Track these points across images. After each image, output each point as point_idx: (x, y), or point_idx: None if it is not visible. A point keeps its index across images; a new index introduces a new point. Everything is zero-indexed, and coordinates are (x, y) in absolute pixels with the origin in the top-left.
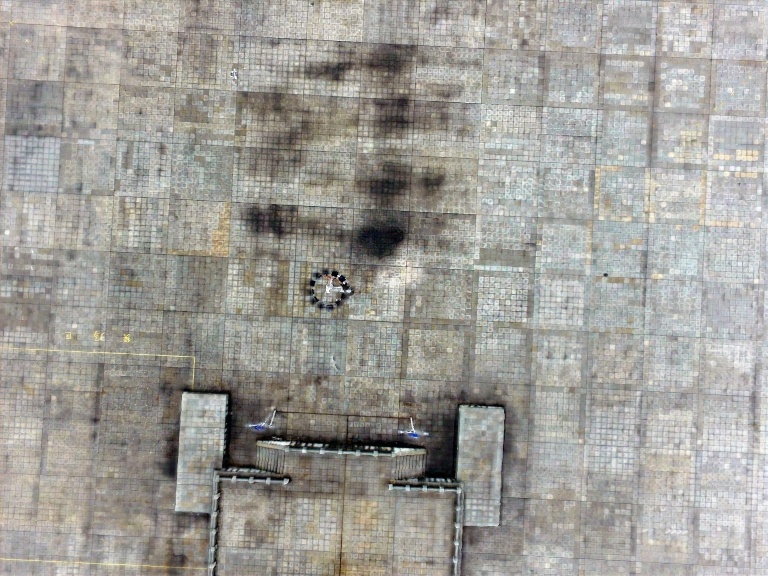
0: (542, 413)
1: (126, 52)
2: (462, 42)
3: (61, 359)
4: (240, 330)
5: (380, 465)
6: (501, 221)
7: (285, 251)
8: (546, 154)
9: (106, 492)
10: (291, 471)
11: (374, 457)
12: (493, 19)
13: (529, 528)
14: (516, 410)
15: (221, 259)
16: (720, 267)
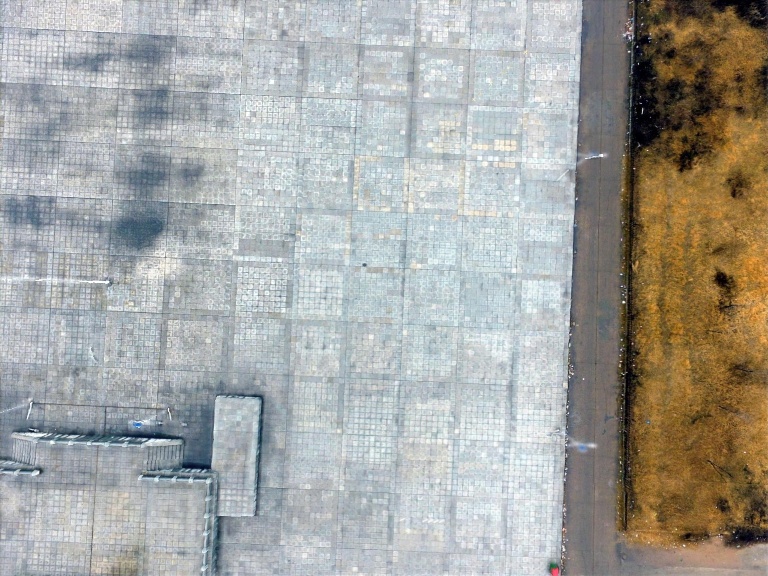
0: (300, 403)
1: None
2: (221, 33)
3: None
4: None
5: (132, 456)
6: (260, 211)
7: (43, 242)
8: (305, 144)
9: None
10: (43, 462)
11: (126, 448)
12: (252, 10)
13: (286, 518)
14: (274, 400)
15: None
16: (478, 256)
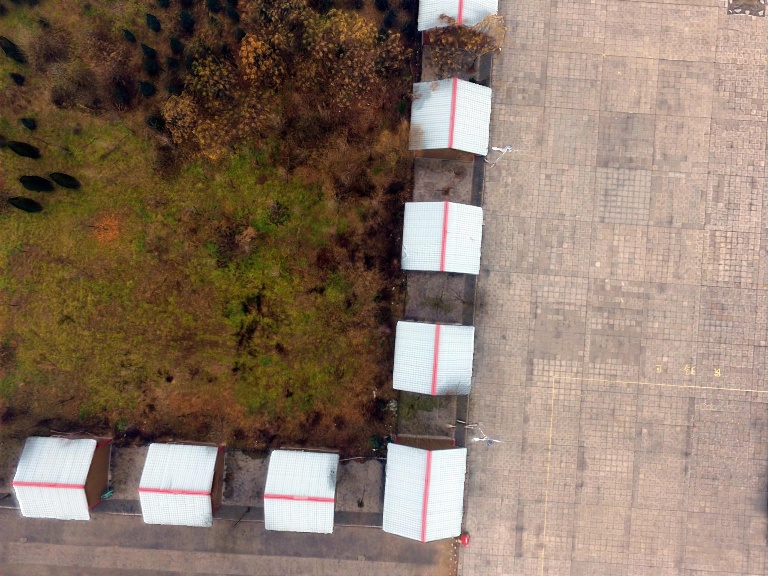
0: None
1: (718, 85)
2: None
3: (652, 392)
4: None
5: None
6: None
7: None
8: None
9: (698, 527)
10: None
11: None
12: None
13: None
14: None
15: None
16: None
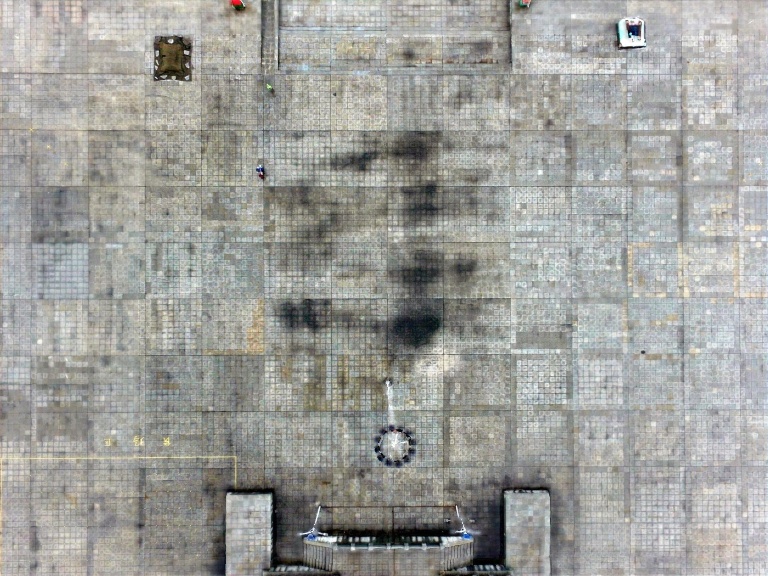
0: (587, 494)
1: (149, 153)
2: (487, 125)
3: (102, 466)
4: (280, 427)
5: (429, 557)
6: (536, 304)
7: (321, 345)
8: (577, 234)
9: None
10: (340, 568)
11: (422, 549)
12: (517, 101)
13: None
14: (561, 492)
15: (257, 357)
16: (757, 338)
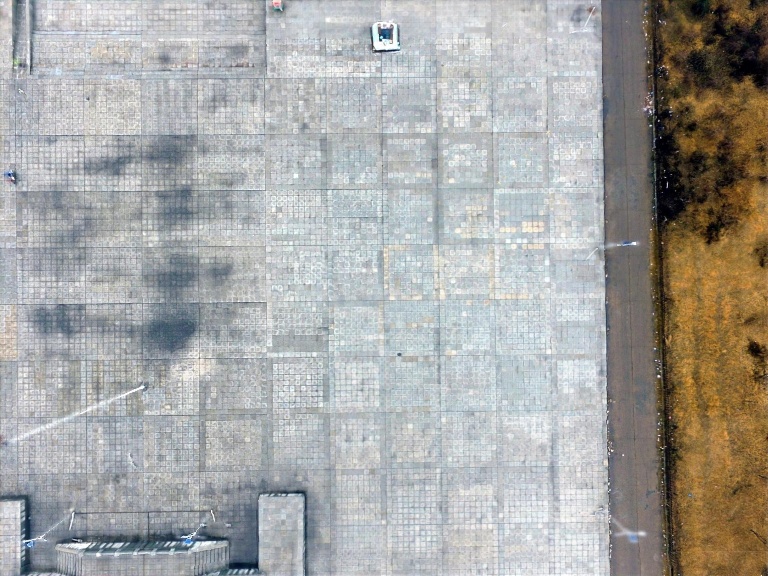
0: (343, 497)
1: None
2: (242, 129)
3: None
4: (34, 433)
5: (179, 562)
6: (292, 307)
7: (75, 351)
8: (333, 237)
9: None
10: (89, 574)
11: (172, 555)
12: (272, 104)
13: None
14: (317, 495)
15: (10, 363)
16: (512, 340)
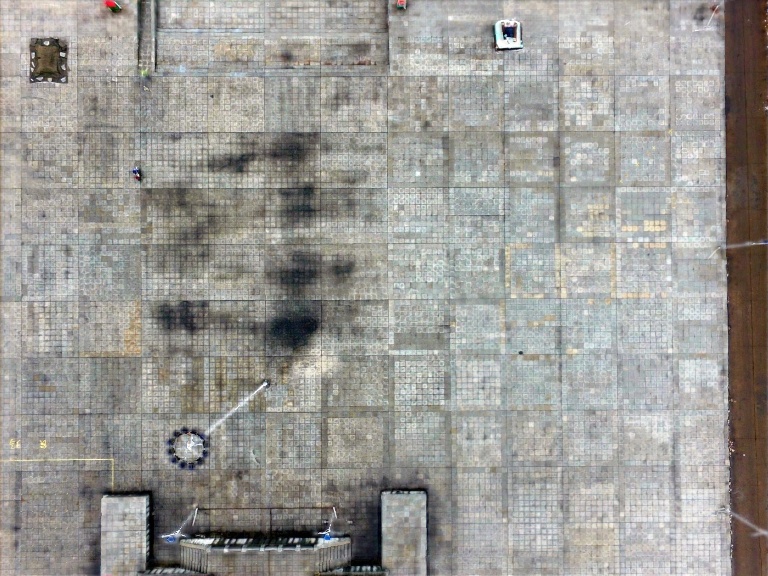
0: (464, 494)
1: (26, 155)
2: (365, 127)
3: None
4: (157, 429)
5: (304, 558)
6: (414, 305)
7: (198, 347)
8: (455, 235)
9: None
10: (215, 570)
11: (297, 551)
12: (395, 102)
13: None
14: (438, 493)
15: (134, 359)
16: (634, 338)
